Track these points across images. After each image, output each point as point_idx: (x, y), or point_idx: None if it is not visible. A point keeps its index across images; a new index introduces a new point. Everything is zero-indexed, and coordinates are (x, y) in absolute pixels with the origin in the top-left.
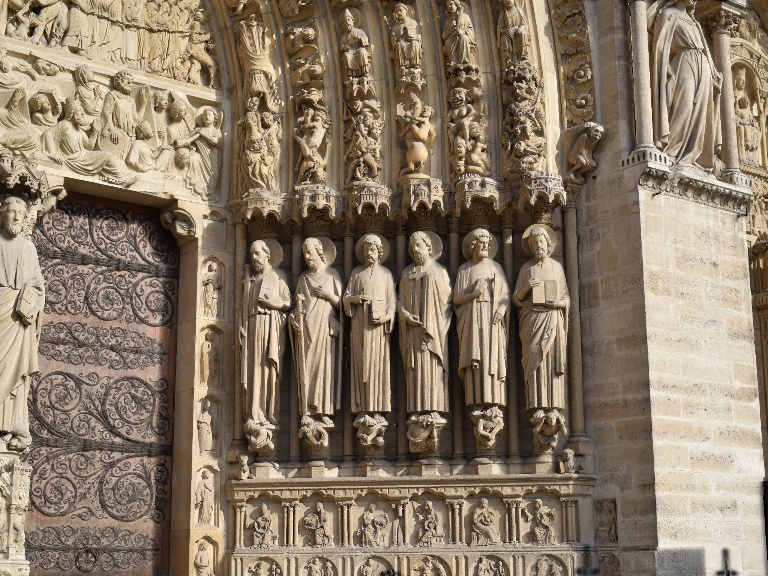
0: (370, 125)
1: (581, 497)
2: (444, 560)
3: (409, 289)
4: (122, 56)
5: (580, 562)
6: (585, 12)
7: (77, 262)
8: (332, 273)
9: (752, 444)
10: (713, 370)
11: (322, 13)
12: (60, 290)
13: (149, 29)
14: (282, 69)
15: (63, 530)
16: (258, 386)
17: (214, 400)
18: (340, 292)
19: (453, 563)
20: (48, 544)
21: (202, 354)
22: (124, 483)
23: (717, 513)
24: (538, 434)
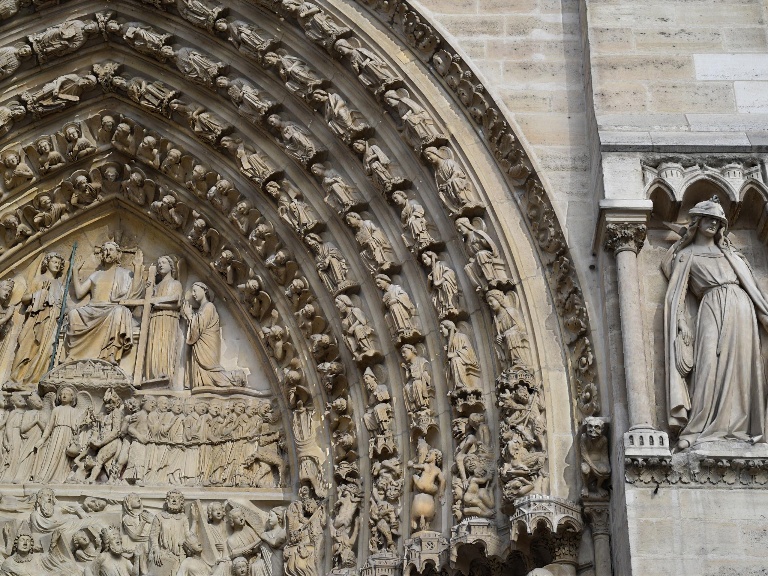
0: (384, 487)
1: None
2: None
3: None
4: (180, 476)
5: None
6: (581, 288)
7: None
8: None
9: None
10: None
11: (356, 379)
12: None
13: (211, 443)
14: (331, 449)
15: None
16: None
17: None
18: None
19: None
20: None
21: None
22: None
23: None
24: None
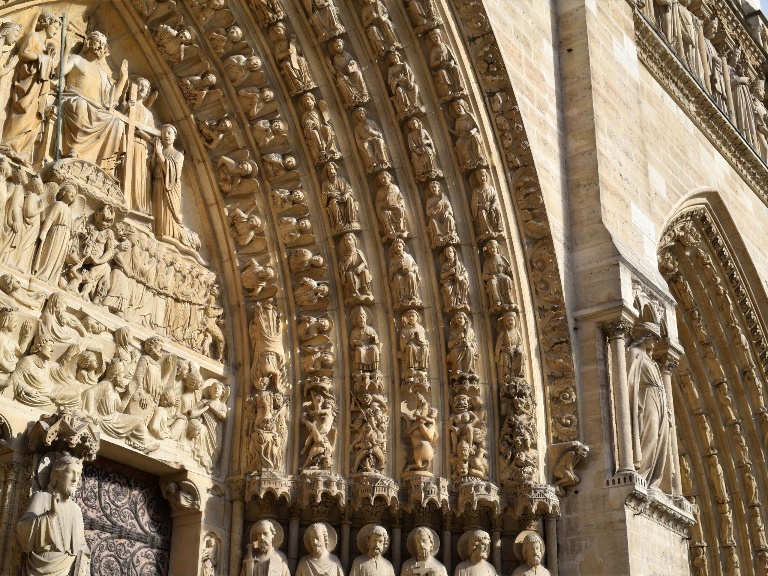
0: (380, 419)
1: None
2: None
3: None
4: (152, 322)
5: None
6: (571, 341)
7: (86, 526)
8: (335, 560)
9: None
10: None
11: (335, 307)
12: None
13: (175, 298)
14: (291, 353)
15: None
16: None
17: None
18: None
19: None
20: None
21: None
22: None
23: None
24: None
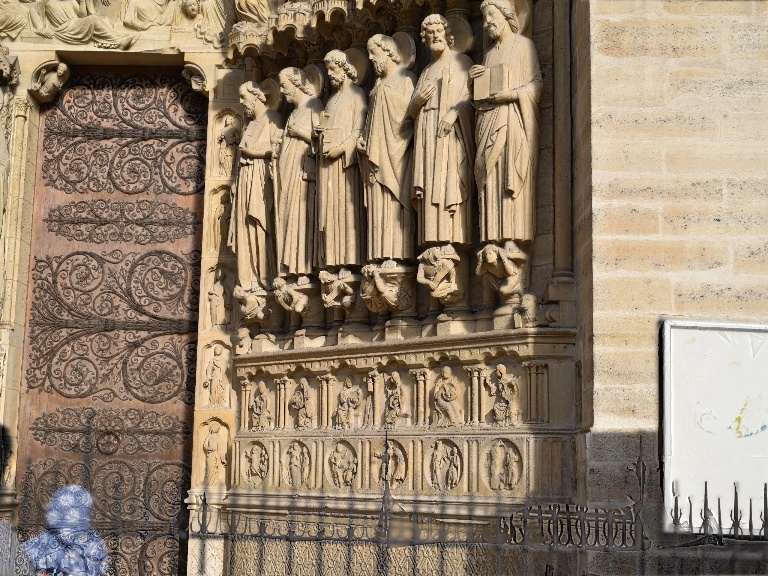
0: None
1: (555, 360)
2: (402, 445)
3: None
4: None
5: (541, 449)
6: None
7: (99, 137)
8: (311, 106)
9: None
10: (740, 158)
11: None
12: (82, 168)
13: None
14: None
15: (84, 412)
16: (245, 248)
17: (228, 268)
18: None
19: (410, 449)
20: (68, 426)
21: (214, 219)
22: (151, 363)
23: None
24: (490, 277)
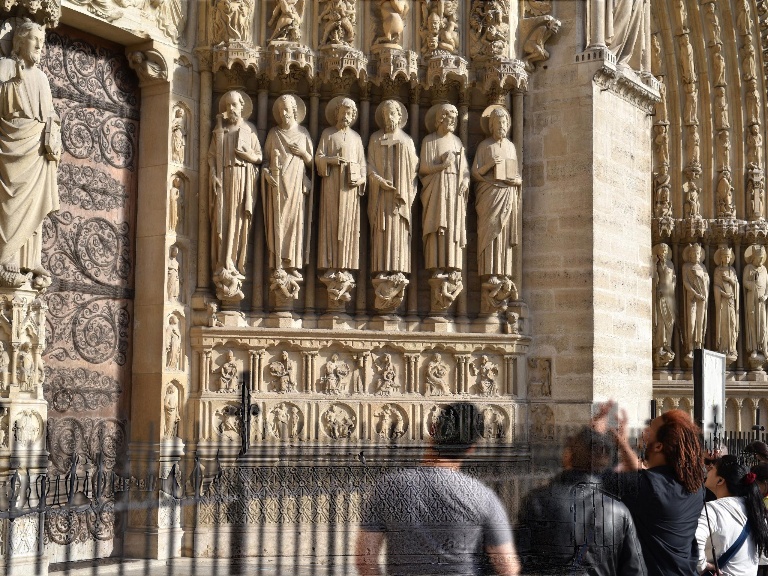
0: None
1: (519, 355)
2: (402, 408)
3: (381, 155)
4: None
5: (519, 412)
6: None
7: (53, 95)
8: (304, 132)
9: (646, 315)
10: (628, 250)
11: None
12: None
13: None
14: None
15: None
16: (232, 237)
17: (180, 247)
18: (312, 151)
19: (410, 411)
20: None
21: (171, 200)
22: (93, 325)
23: (626, 373)
24: (491, 298)
